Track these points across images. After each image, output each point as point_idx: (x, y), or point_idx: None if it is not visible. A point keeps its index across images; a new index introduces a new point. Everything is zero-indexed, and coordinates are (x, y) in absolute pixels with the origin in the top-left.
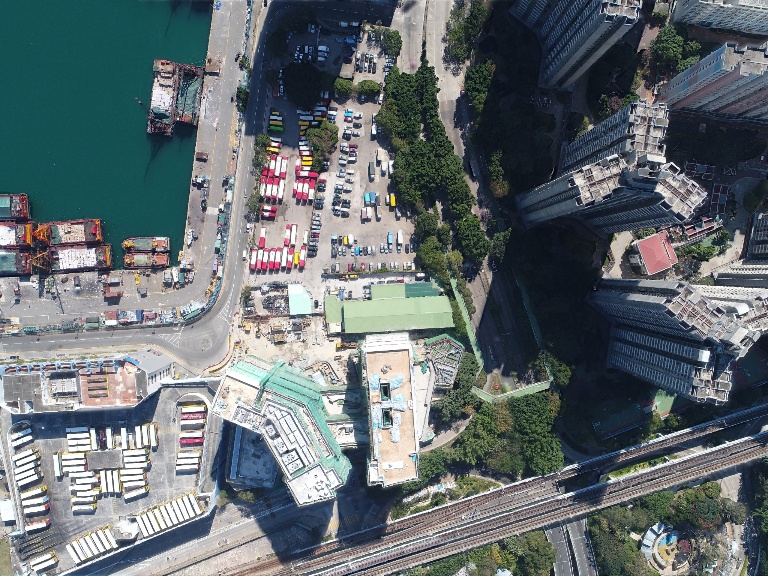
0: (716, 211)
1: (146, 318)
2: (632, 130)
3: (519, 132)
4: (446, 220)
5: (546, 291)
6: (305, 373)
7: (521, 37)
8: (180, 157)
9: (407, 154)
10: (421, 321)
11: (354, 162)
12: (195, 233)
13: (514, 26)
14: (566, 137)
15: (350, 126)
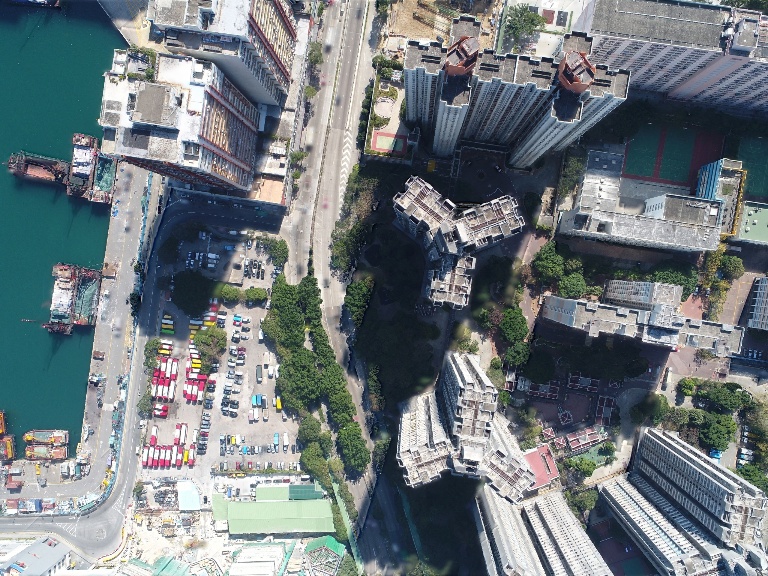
0: (600, 425)
1: (45, 507)
2: (460, 413)
3: (397, 348)
4: (331, 423)
5: (429, 496)
6: (192, 568)
7: (402, 251)
8: (79, 354)
9: (289, 365)
10: (303, 525)
11: (243, 364)
12: (92, 428)
13: (399, 235)
14: (450, 346)
15: (238, 330)
